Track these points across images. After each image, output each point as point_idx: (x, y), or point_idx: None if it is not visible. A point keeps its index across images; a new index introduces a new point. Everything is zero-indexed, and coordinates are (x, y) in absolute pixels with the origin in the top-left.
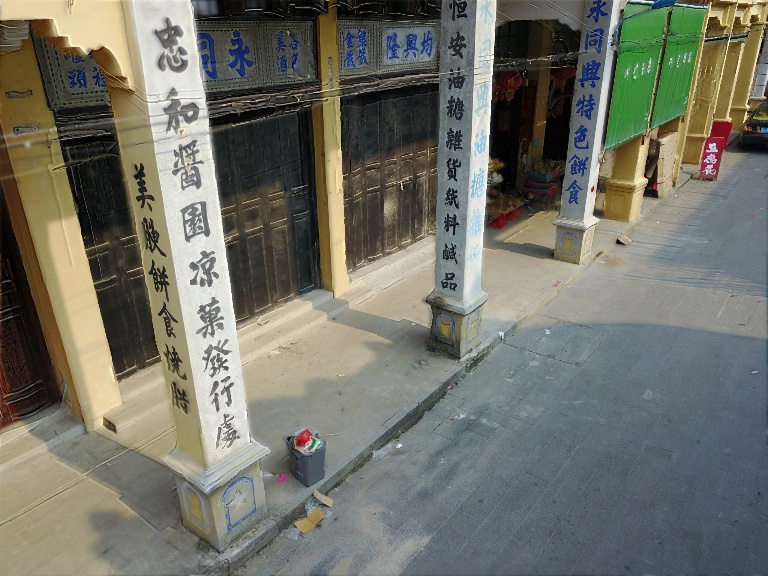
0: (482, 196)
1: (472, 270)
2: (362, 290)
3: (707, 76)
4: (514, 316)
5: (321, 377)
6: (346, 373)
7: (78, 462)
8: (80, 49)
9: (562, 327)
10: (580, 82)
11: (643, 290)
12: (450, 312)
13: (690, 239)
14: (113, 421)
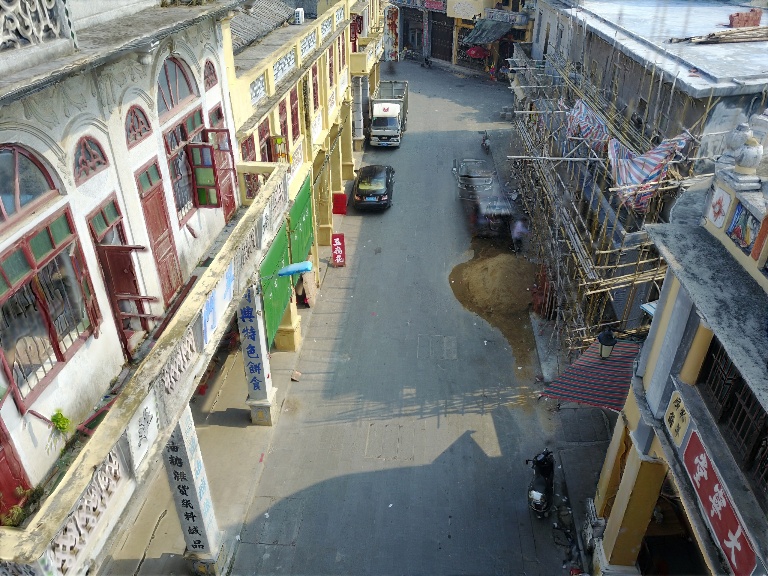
0: (206, 489)
1: (211, 530)
2: None
3: (321, 187)
4: (242, 513)
5: None
6: None
7: None
8: None
9: (275, 506)
10: (241, 319)
11: (318, 438)
12: (204, 563)
13: (338, 359)
14: None
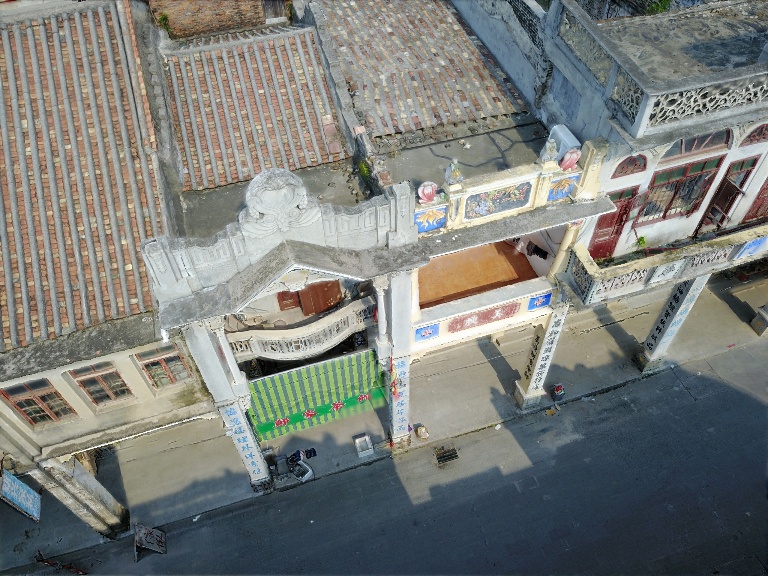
0: (678, 326)
1: (662, 346)
2: (623, 307)
3: None
4: (688, 358)
5: (579, 354)
6: (590, 356)
7: (486, 354)
8: (535, 325)
9: (709, 374)
10: None
11: None
12: None
13: None
14: (499, 342)
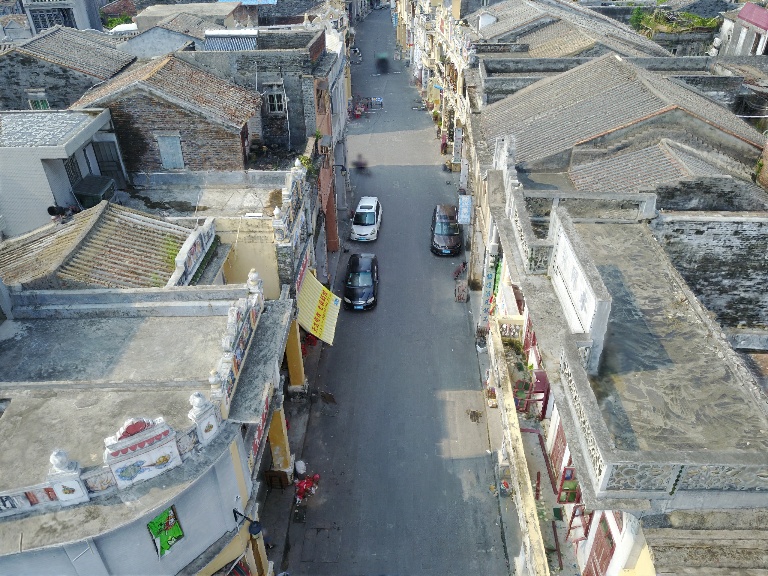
0: None
1: None
2: None
3: None
4: None
5: None
6: None
7: None
8: None
9: None
10: None
11: None
12: None
13: None
14: None
